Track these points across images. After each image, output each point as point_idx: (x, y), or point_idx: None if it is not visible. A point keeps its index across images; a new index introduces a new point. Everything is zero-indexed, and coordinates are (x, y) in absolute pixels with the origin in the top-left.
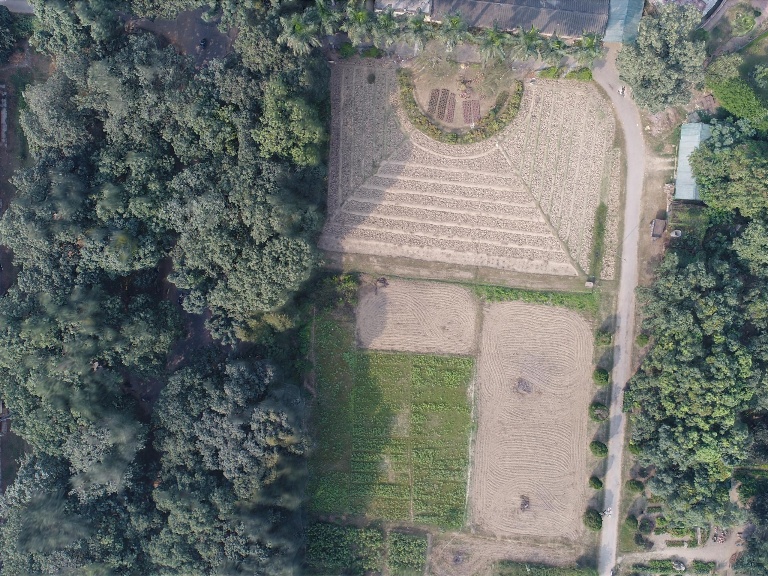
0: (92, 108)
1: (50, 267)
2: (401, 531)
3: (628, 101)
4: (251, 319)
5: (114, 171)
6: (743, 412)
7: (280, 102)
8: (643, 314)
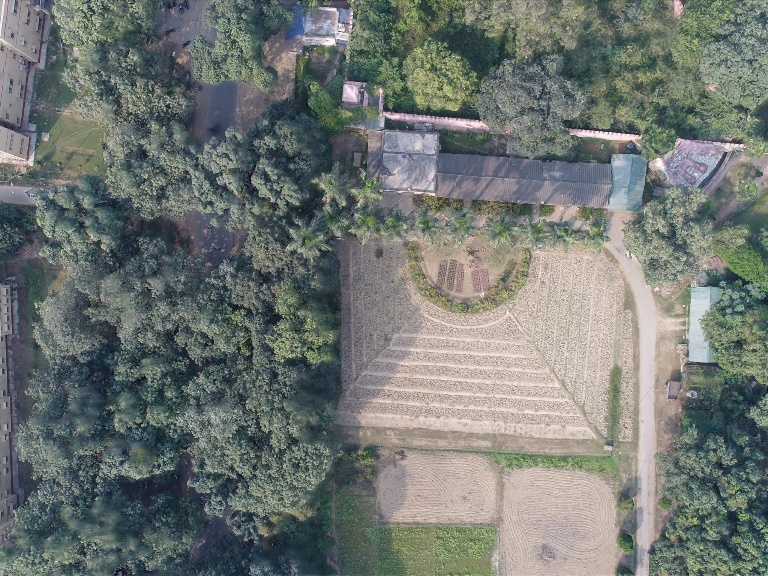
0: (105, 320)
1: (70, 480)
2: None
3: (636, 263)
4: (273, 515)
5: (130, 378)
6: None
7: (293, 308)
8: (664, 479)
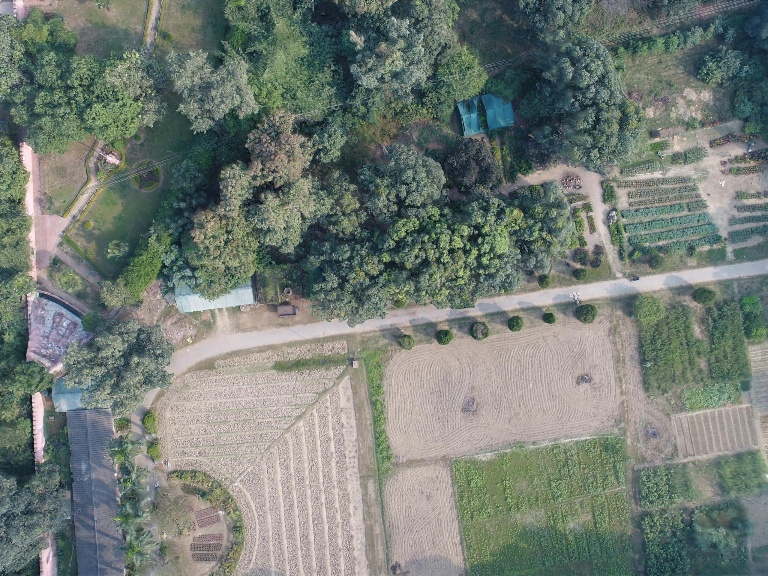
0: None
1: None
2: (638, 496)
3: None
4: None
5: None
6: (450, 187)
7: None
8: None
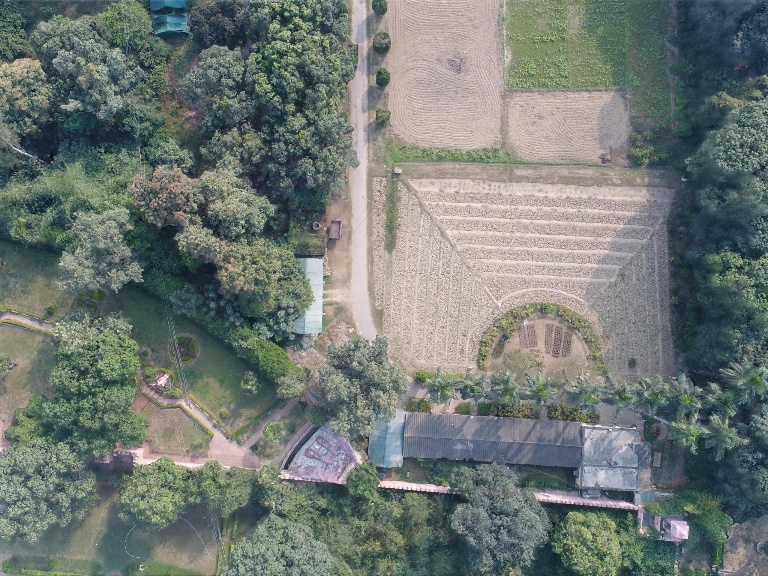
0: None
1: None
2: None
3: None
4: (760, 97)
5: None
6: None
7: (761, 309)
8: None
